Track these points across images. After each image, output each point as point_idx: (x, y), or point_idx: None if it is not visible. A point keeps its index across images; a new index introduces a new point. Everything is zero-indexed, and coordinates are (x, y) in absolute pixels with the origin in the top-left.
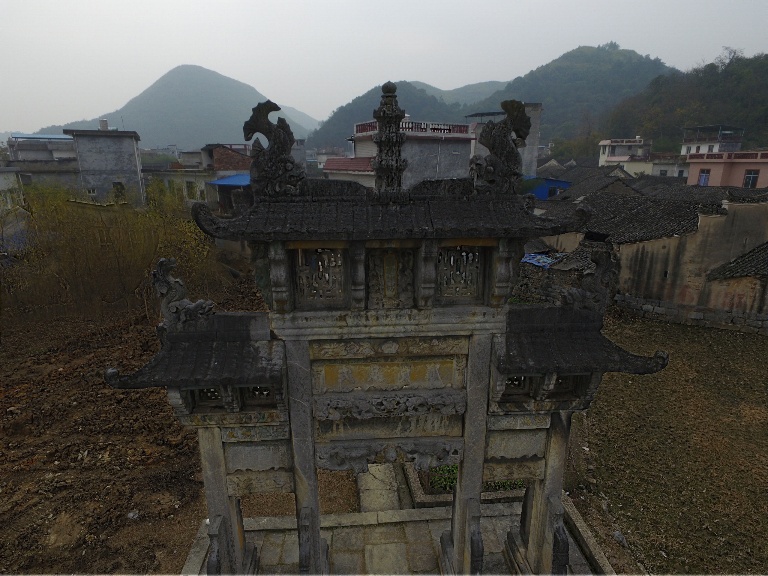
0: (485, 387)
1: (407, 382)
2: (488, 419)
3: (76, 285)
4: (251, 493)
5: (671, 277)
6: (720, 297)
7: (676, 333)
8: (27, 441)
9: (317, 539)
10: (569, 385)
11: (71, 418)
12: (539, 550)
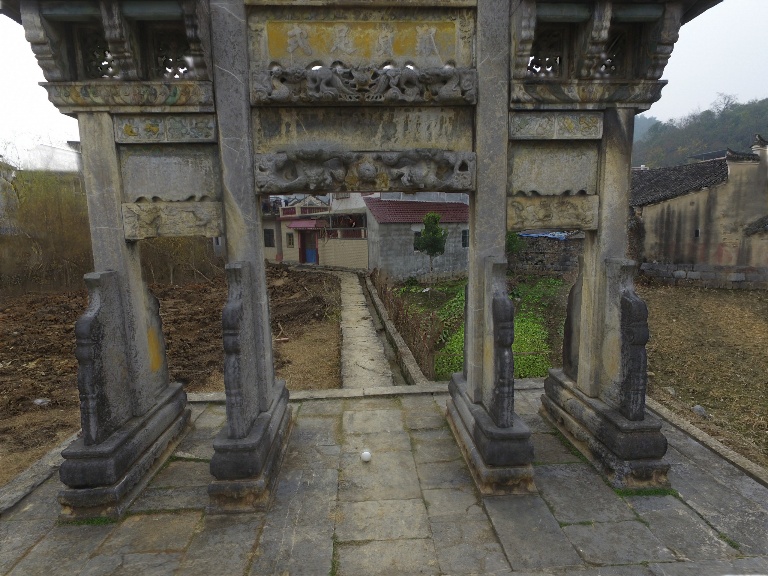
0: (504, 61)
1: (389, 56)
2: (510, 120)
3: (46, 241)
4: (159, 235)
5: (703, 236)
6: (762, 253)
7: (717, 293)
8: None
9: (259, 321)
10: (627, 72)
11: None
12: (597, 355)
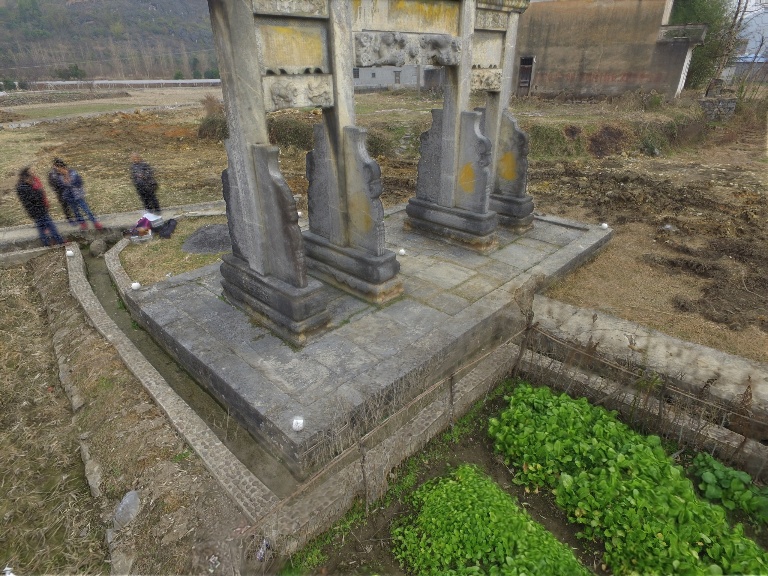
0: None
1: None
2: None
3: None
4: None
5: None
6: None
7: None
8: None
9: None
10: None
11: None
12: None
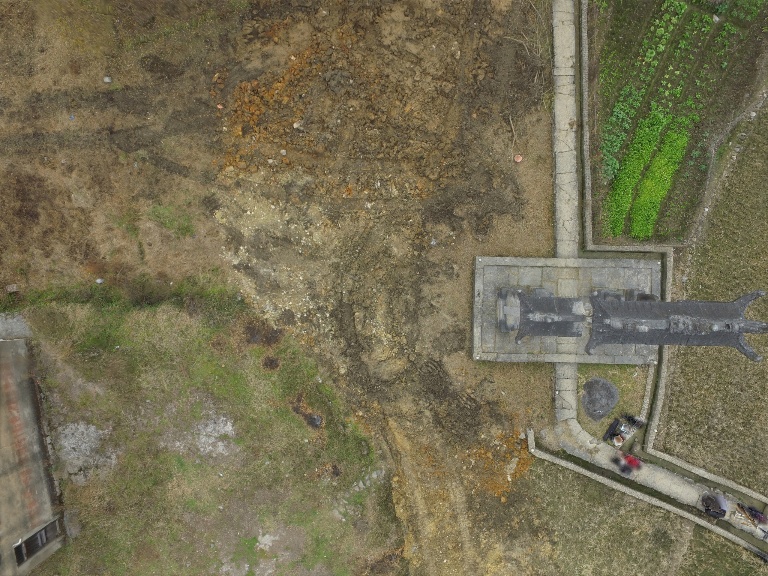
0: None
1: None
2: None
3: None
4: None
5: None
6: None
7: None
8: (331, 165)
9: None
10: None
11: (344, 138)
12: None
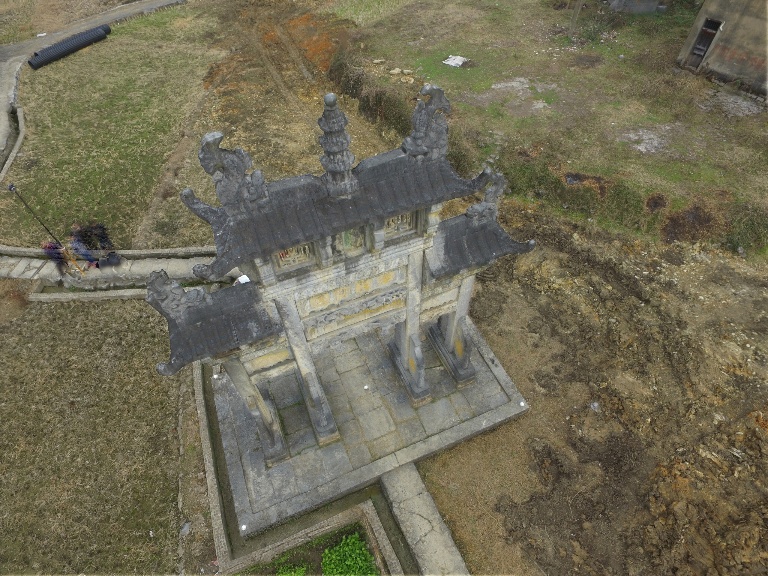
0: None
1: None
2: None
3: None
4: None
5: None
6: None
7: None
8: None
9: None
10: None
11: None
12: None
